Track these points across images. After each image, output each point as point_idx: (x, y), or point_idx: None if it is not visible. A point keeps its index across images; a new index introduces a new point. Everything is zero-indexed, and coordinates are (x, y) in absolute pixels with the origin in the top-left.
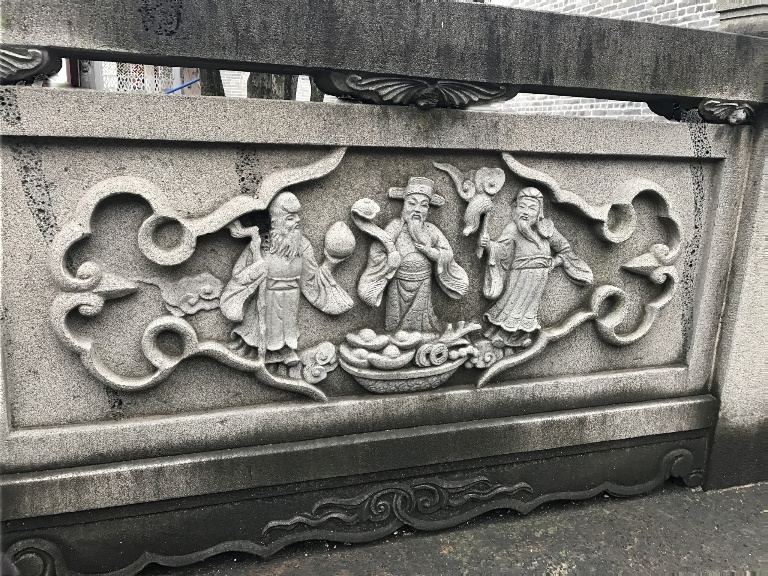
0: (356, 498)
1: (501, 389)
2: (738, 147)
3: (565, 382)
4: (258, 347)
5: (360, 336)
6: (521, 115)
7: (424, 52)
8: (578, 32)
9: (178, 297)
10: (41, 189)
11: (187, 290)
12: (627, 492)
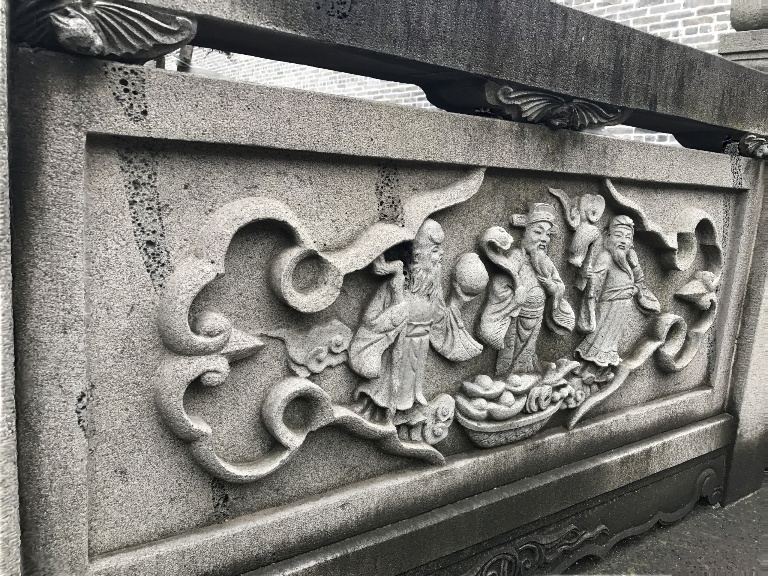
0: (469, 573)
1: (588, 428)
2: (757, 179)
3: (634, 414)
4: (388, 407)
5: (479, 384)
6: (624, 140)
7: (567, 67)
8: (676, 60)
9: (306, 352)
10: (152, 213)
11: (316, 343)
12: (673, 519)
